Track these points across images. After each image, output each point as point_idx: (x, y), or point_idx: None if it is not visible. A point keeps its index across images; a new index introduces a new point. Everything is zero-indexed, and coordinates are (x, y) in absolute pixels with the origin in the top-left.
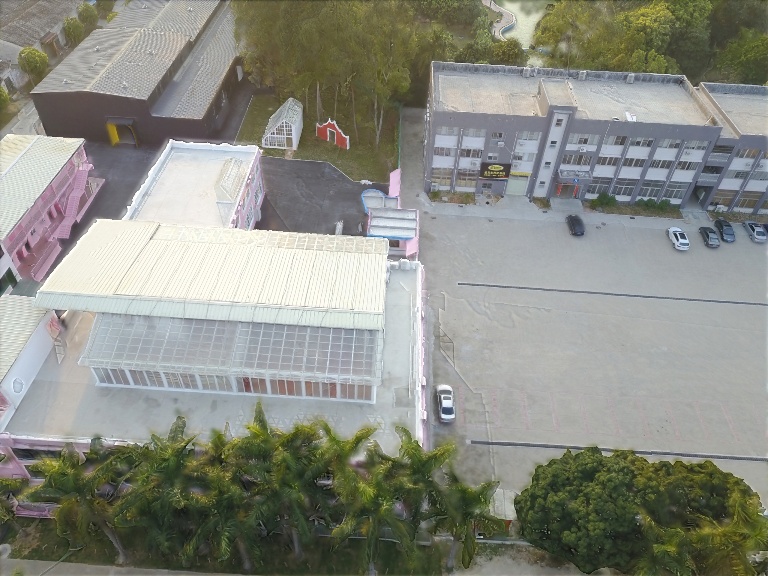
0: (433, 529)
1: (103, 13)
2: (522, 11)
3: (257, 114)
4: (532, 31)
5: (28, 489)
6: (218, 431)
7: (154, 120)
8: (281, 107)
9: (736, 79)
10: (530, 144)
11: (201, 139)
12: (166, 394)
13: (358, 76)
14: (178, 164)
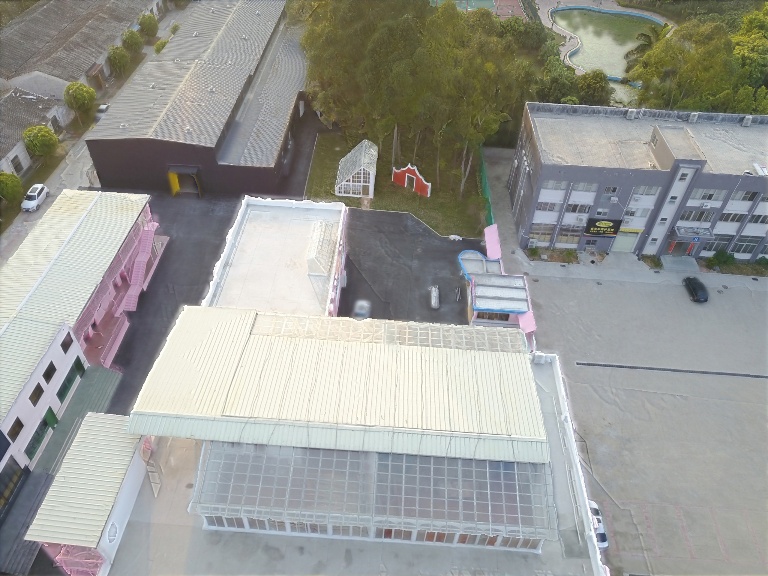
0: None
1: (146, 38)
2: (584, 32)
3: (324, 155)
4: (599, 55)
5: None
6: None
7: (221, 168)
8: (354, 150)
9: None
10: (646, 199)
11: (271, 188)
12: (289, 541)
13: (453, 123)
14: (257, 225)
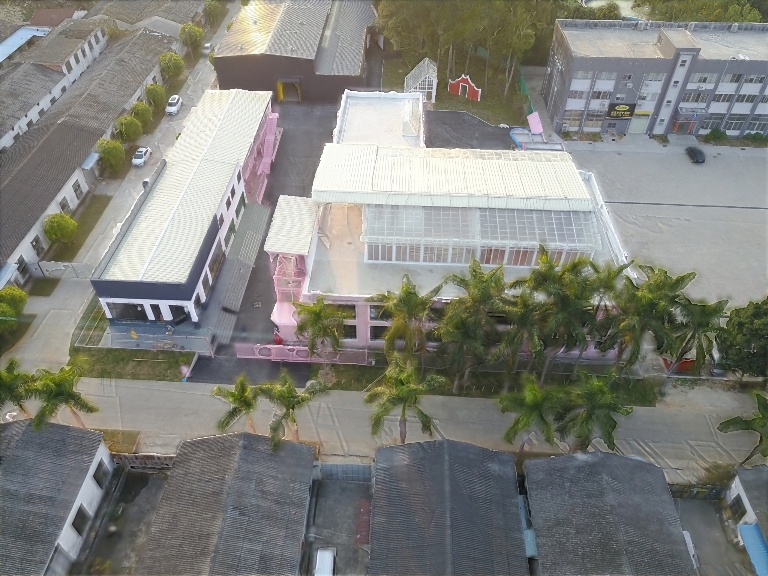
0: (665, 349)
1: None
2: None
3: (391, 75)
4: None
5: (342, 329)
6: None
7: (317, 78)
8: (417, 67)
9: None
10: (655, 85)
11: None
12: (422, 267)
13: (502, 31)
14: (357, 109)
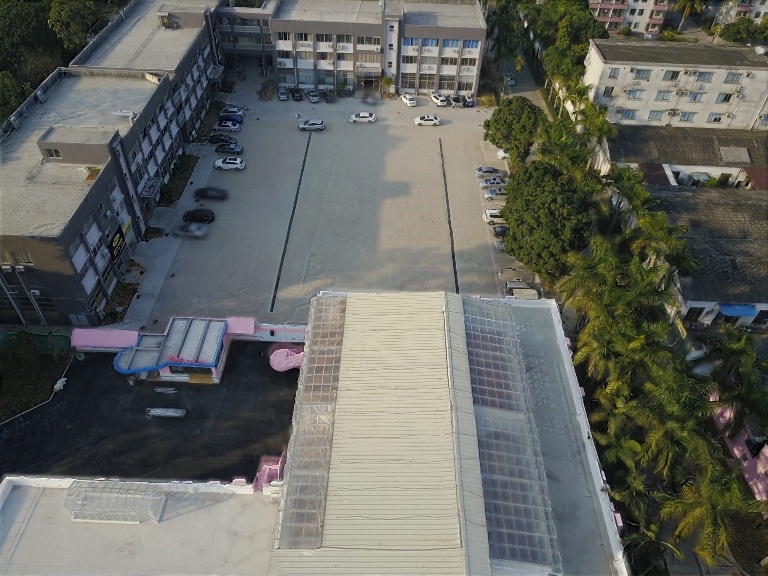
0: None
1: None
2: None
3: None
4: None
5: None
6: (565, 445)
7: None
8: None
9: (35, 57)
10: (115, 194)
11: None
12: None
13: None
14: None
